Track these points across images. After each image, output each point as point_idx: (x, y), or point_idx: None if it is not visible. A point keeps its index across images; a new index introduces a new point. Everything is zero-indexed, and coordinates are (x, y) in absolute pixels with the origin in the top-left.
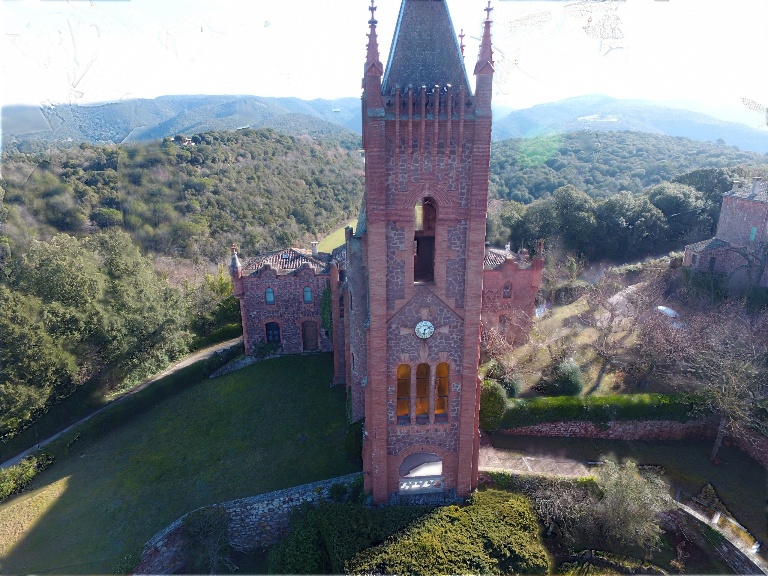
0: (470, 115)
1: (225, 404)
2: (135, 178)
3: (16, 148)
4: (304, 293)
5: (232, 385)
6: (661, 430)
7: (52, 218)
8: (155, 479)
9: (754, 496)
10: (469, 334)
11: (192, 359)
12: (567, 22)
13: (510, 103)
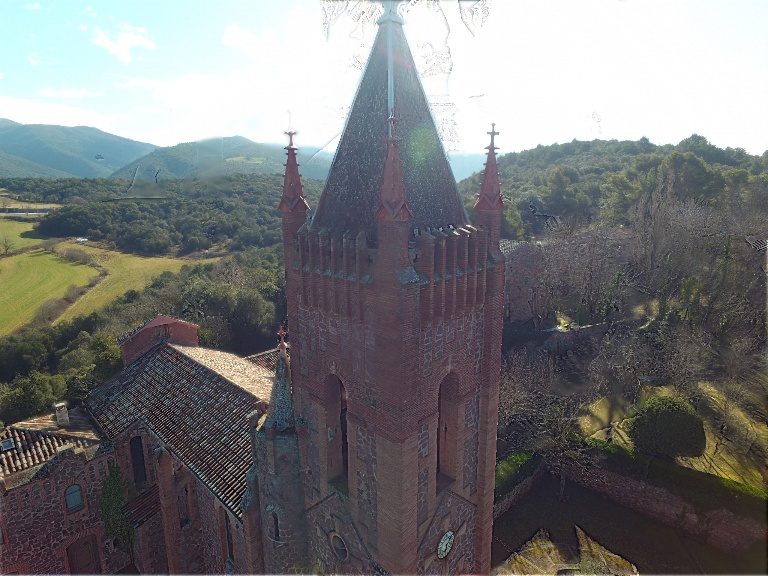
0: (486, 261)
1: None
2: None
3: None
4: (66, 498)
5: None
6: (521, 490)
7: None
8: None
9: (600, 519)
10: (486, 521)
11: None
12: None
13: (224, 160)
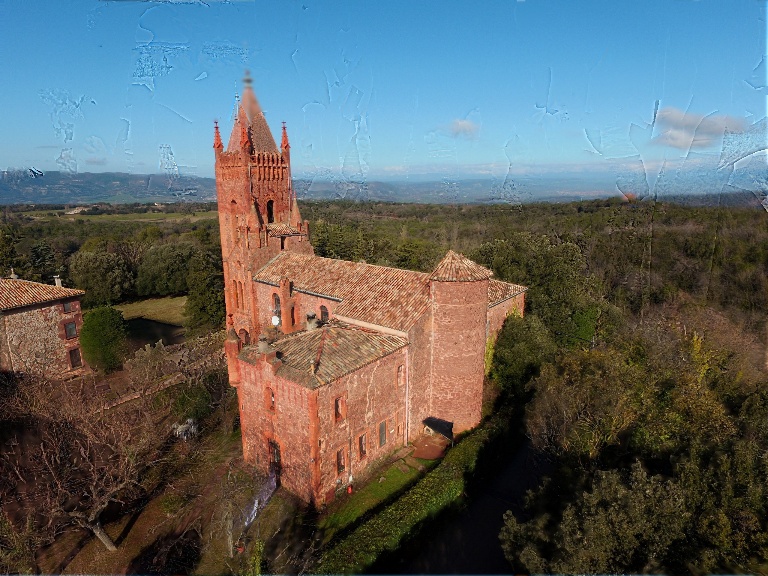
0: None
1: None
2: None
3: None
4: None
5: None
6: None
7: (747, 245)
8: None
9: None
10: None
11: None
12: (187, 59)
13: None
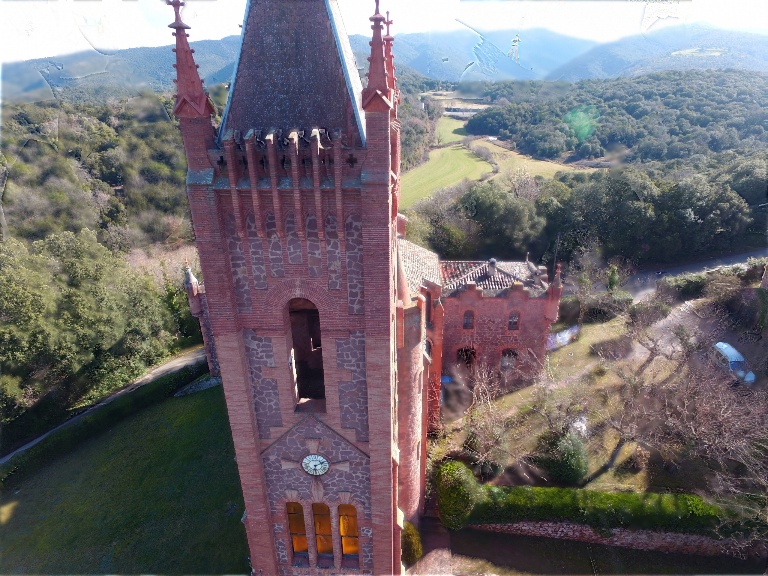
0: (354, 179)
1: (172, 441)
2: (138, 151)
3: (23, 118)
4: None
5: (188, 414)
6: (686, 544)
7: (50, 198)
8: (67, 543)
9: None
10: (376, 478)
11: (170, 365)
12: None
13: None
